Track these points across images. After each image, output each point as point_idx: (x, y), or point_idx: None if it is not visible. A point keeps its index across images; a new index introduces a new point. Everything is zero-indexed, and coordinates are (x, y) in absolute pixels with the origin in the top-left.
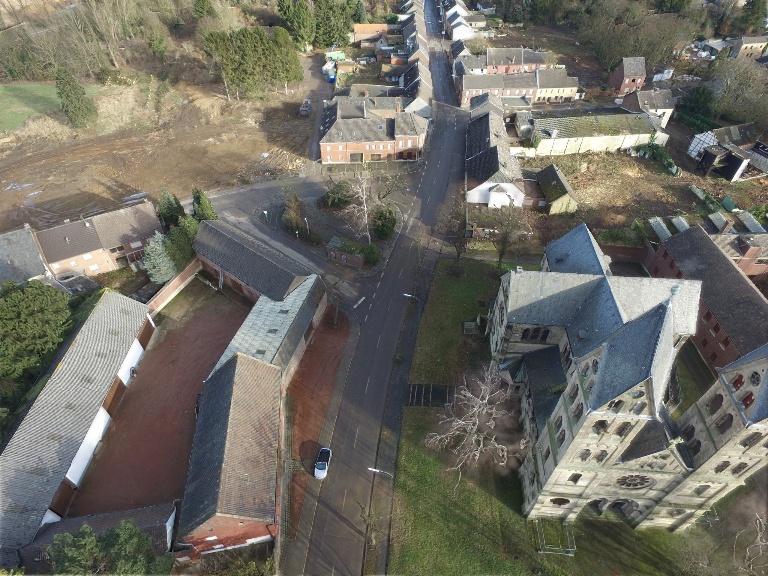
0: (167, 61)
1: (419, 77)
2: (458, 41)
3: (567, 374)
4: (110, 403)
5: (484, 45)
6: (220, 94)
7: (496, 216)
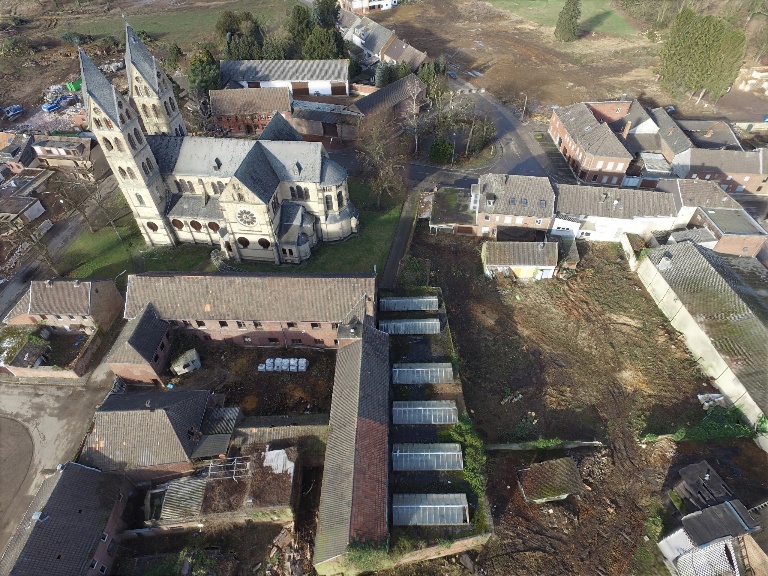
0: None
1: (760, 148)
2: None
3: None
4: (296, 89)
5: None
6: None
7: (455, 205)
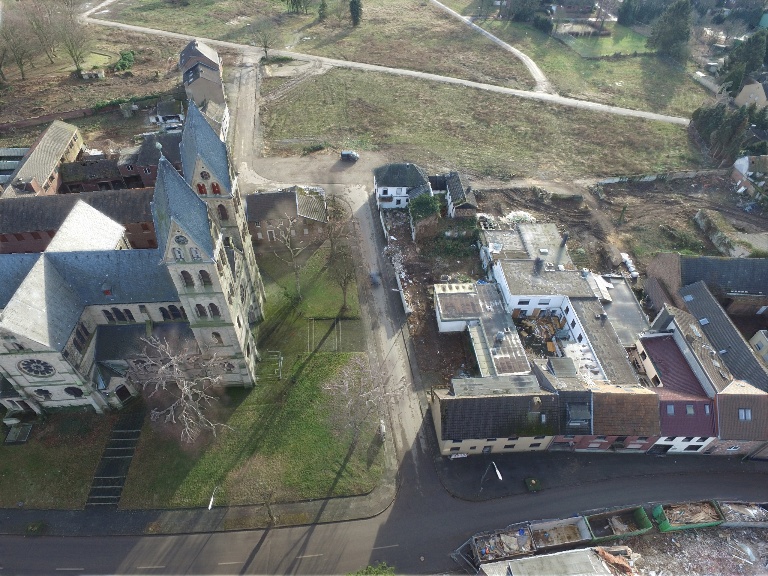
0: None
1: None
2: None
3: (137, 320)
4: None
5: None
6: None
7: None
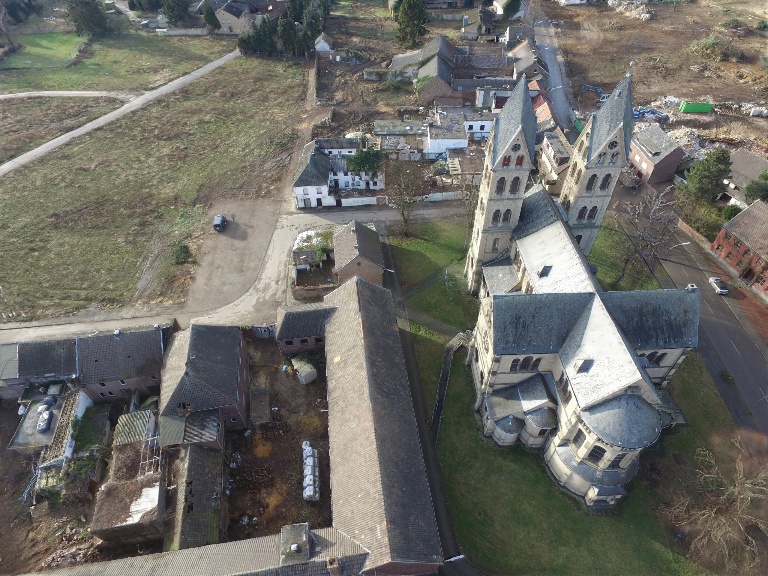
0: None
1: None
2: None
3: None
4: None
5: None
6: None
7: None
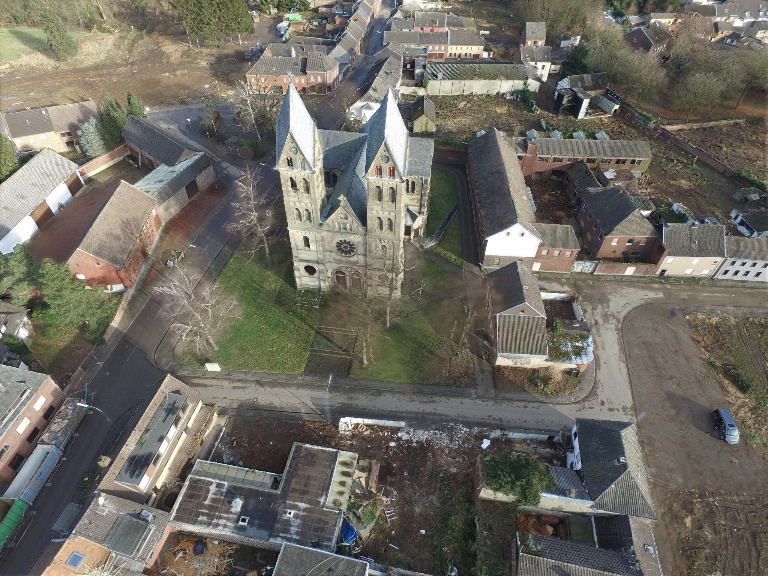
0: (148, 16)
1: (346, 31)
2: (397, 7)
3: None
4: (39, 218)
5: (417, 10)
6: (185, 43)
7: None
